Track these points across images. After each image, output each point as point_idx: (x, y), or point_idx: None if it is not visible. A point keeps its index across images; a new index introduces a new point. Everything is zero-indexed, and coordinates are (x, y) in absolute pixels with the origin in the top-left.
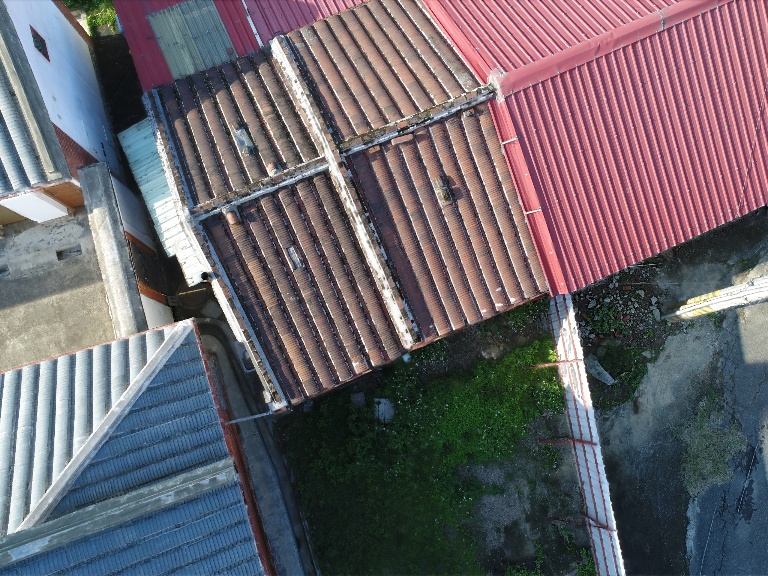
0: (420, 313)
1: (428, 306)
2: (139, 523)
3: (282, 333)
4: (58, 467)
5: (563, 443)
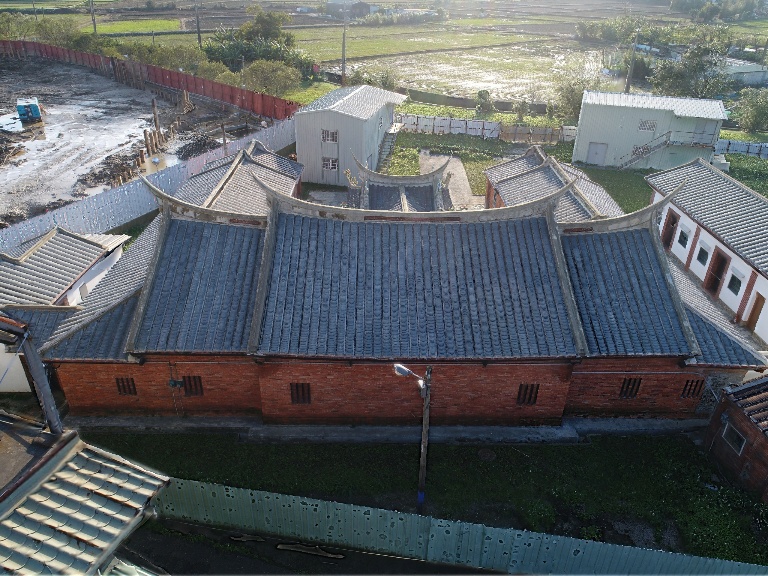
0: None
1: None
2: None
3: None
4: None
5: None
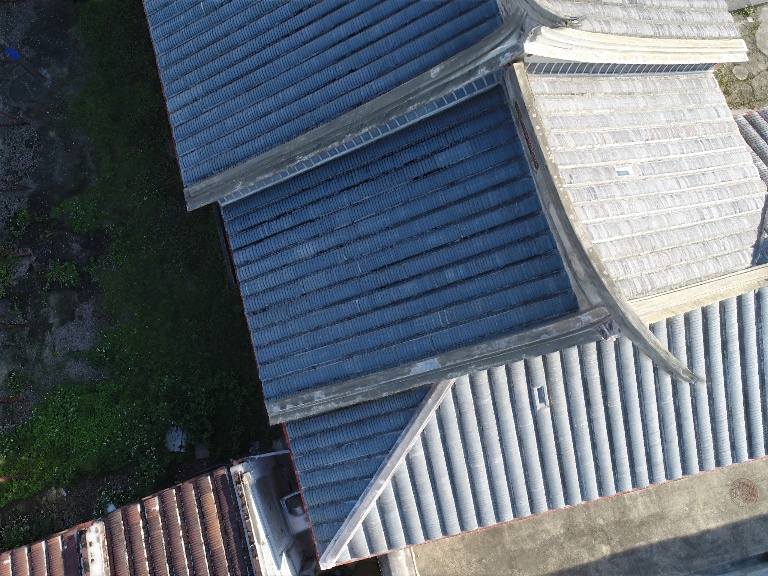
0: (73, 565)
1: (63, 572)
2: (343, 376)
3: (221, 550)
4: (432, 429)
5: (0, 396)
